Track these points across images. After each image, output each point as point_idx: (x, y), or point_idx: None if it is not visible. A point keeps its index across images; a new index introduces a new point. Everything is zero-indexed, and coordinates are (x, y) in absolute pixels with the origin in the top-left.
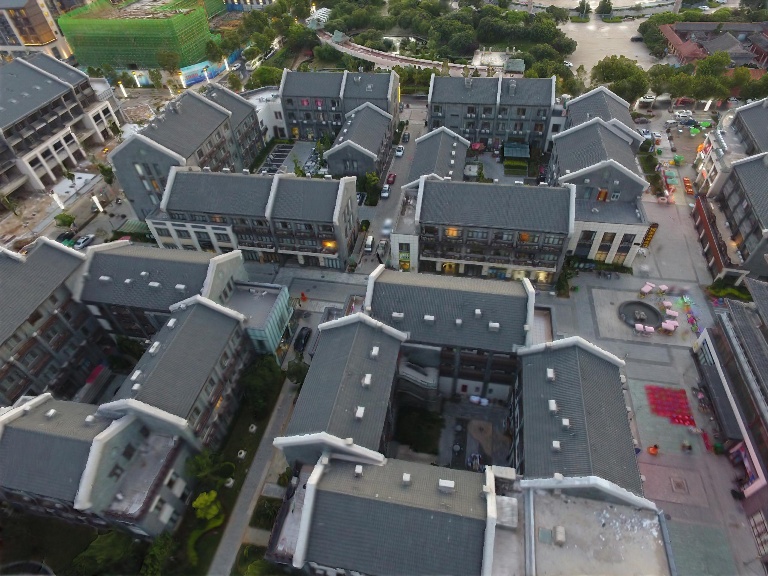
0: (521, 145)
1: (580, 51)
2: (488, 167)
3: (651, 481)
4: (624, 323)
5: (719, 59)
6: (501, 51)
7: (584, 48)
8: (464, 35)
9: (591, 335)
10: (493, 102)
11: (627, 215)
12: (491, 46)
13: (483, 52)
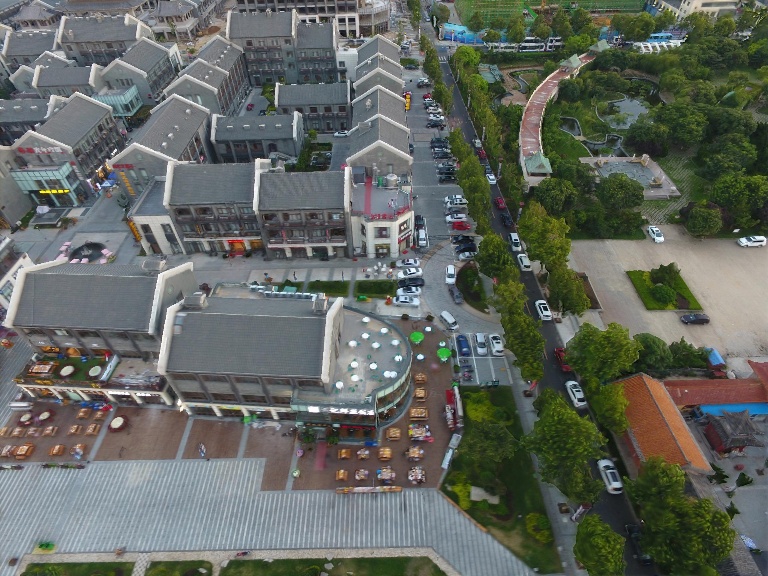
0: None
1: (746, 254)
2: None
3: None
4: None
5: (598, 335)
6: (674, 178)
7: None
8: (648, 127)
9: (80, 229)
10: None
11: (155, 212)
12: (689, 169)
13: (634, 157)
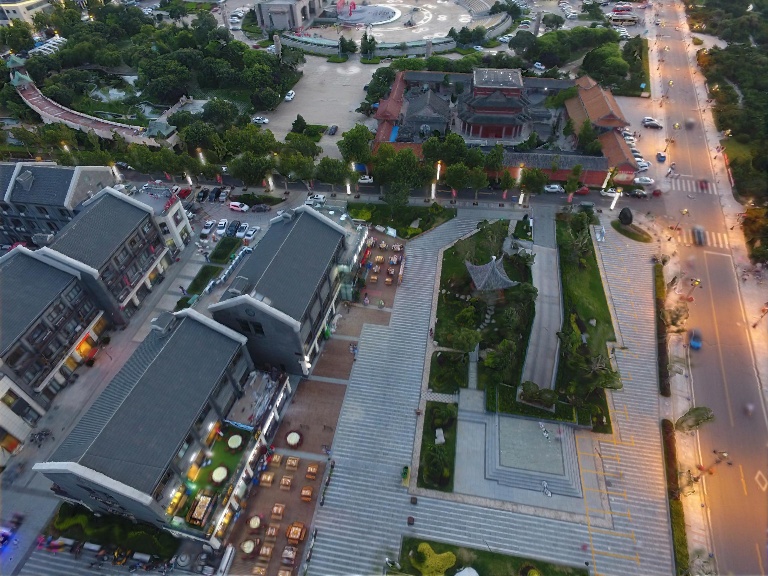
0: None
1: (297, 102)
2: None
3: None
4: None
5: (353, 134)
6: None
7: (305, 98)
8: (162, 81)
9: None
10: (3, 198)
11: None
12: (209, 92)
13: (181, 102)
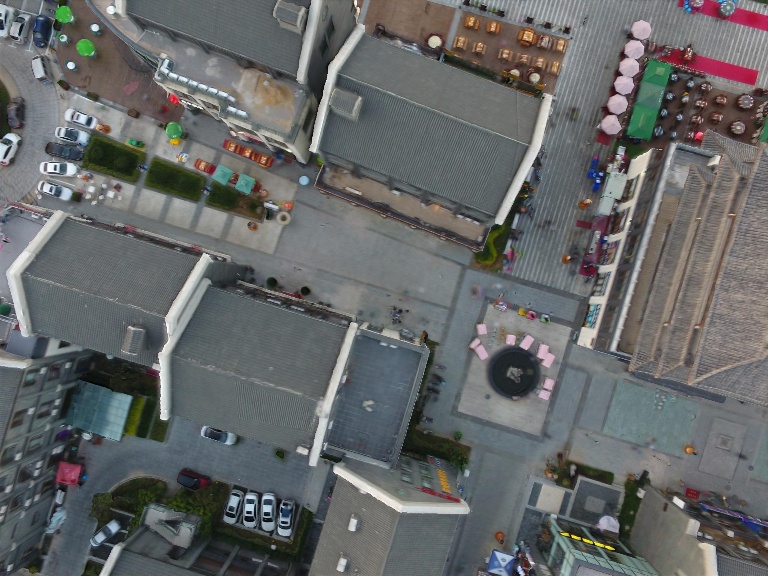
0: (85, 398)
1: None
2: (131, 462)
3: (718, 467)
4: (523, 399)
5: None
6: None
7: None
8: None
9: (536, 447)
10: None
11: (387, 361)
12: None
13: None
